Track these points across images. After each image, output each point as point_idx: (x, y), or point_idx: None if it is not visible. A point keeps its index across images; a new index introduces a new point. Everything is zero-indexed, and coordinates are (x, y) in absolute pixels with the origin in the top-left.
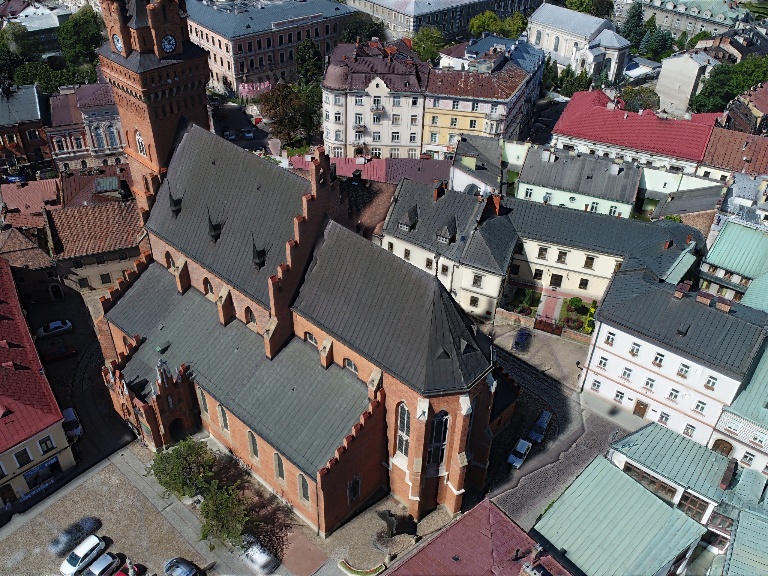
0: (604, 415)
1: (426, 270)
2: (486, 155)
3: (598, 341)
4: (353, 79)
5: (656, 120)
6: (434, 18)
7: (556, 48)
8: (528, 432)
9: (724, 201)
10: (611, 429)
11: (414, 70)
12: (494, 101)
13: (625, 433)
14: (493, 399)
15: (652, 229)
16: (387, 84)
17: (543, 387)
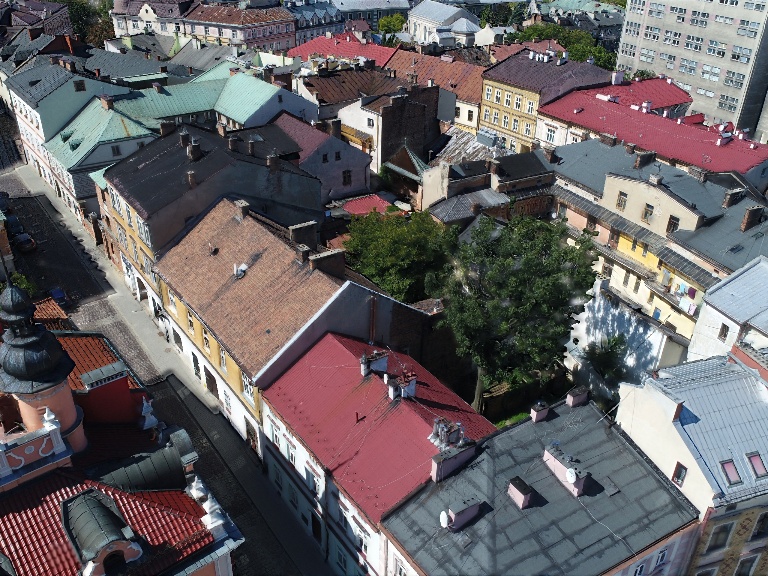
0: (20, 175)
1: (7, 92)
2: (163, 47)
3: (14, 107)
4: (131, 6)
5: (358, 45)
6: (347, 17)
7: (425, 37)
8: None
9: (295, 72)
10: (12, 181)
11: (181, 1)
12: (231, 26)
13: (18, 184)
14: None
15: (173, 67)
16: (156, 11)
17: (5, 160)
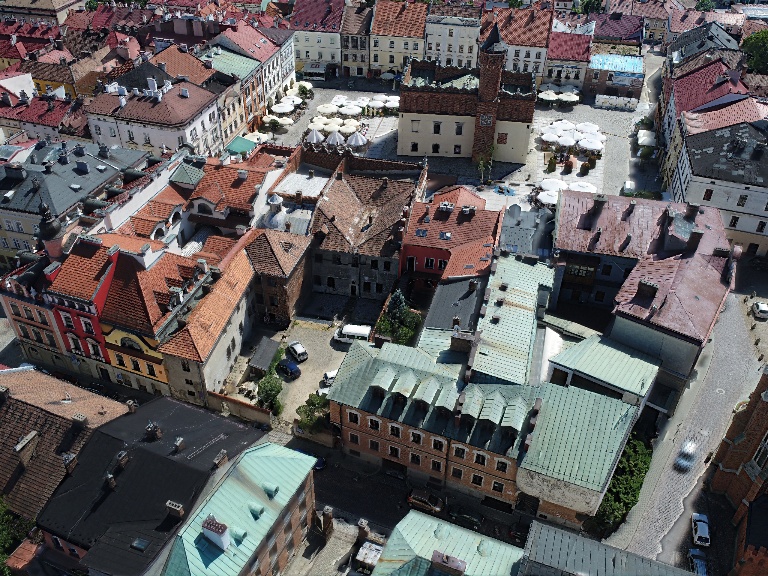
0: None
1: None
2: None
3: None
4: None
5: None
6: None
7: None
8: (708, 566)
9: None
10: None
11: None
12: None
13: None
14: (767, 530)
15: None
16: None
17: None
